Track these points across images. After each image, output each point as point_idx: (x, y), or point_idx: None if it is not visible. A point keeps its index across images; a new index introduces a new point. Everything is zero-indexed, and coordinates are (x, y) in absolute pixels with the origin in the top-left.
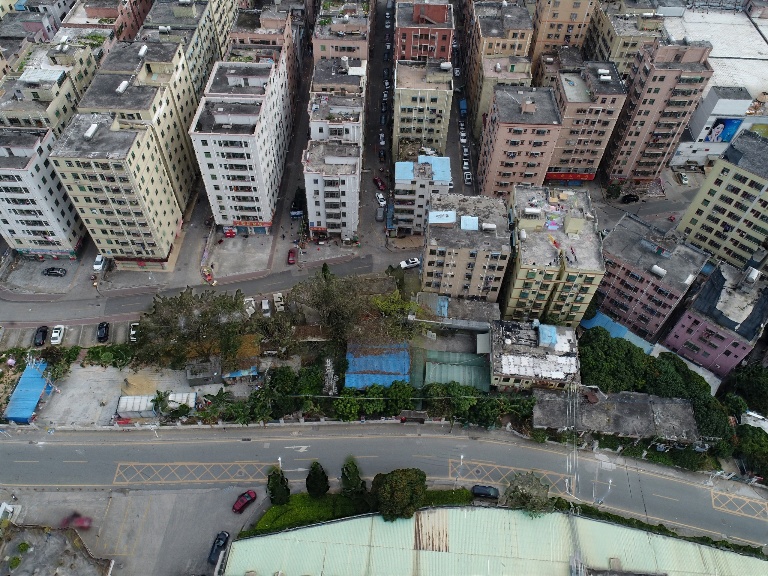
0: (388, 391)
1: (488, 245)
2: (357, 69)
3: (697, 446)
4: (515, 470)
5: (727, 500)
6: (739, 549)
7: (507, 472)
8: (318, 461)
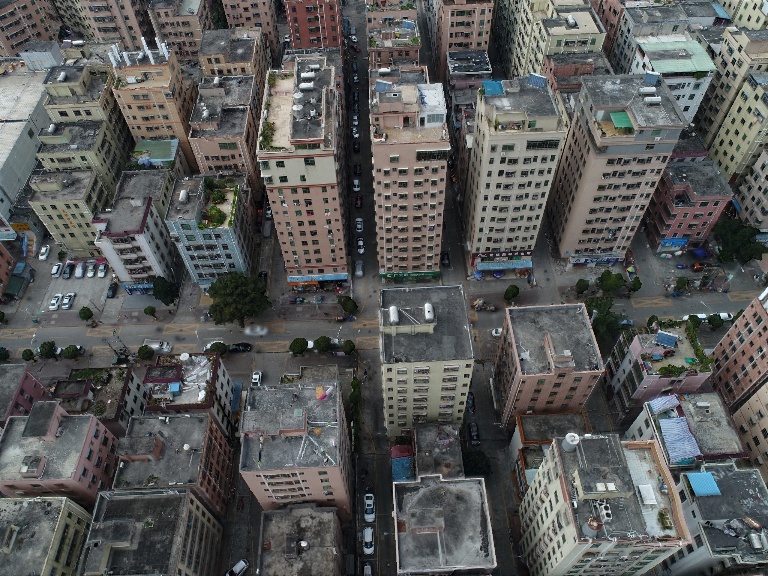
0: None
1: None
2: None
3: None
4: None
5: None
6: None
7: None
8: None
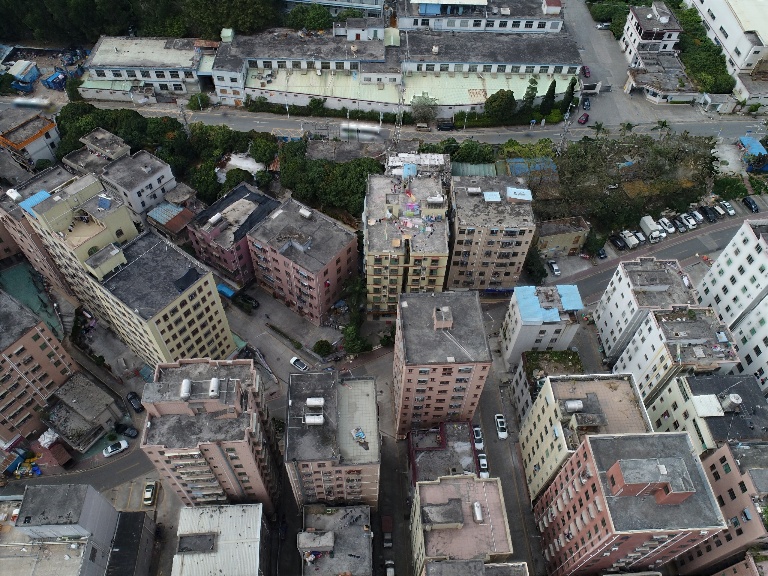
0: (521, 146)
1: (473, 180)
2: (708, 408)
3: (314, 133)
4: (427, 139)
5: (296, 134)
6: (303, 109)
7: (432, 138)
8: (550, 138)
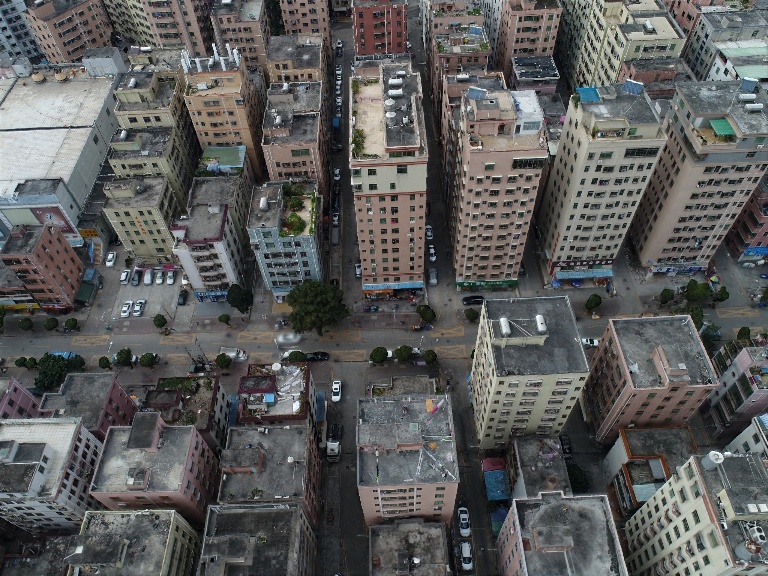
0: None
1: None
2: None
3: None
4: None
5: None
6: None
7: None
8: None
